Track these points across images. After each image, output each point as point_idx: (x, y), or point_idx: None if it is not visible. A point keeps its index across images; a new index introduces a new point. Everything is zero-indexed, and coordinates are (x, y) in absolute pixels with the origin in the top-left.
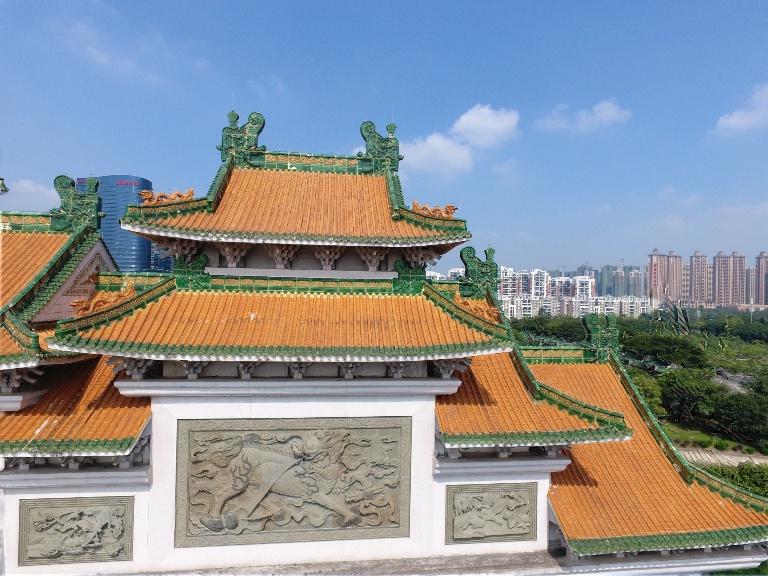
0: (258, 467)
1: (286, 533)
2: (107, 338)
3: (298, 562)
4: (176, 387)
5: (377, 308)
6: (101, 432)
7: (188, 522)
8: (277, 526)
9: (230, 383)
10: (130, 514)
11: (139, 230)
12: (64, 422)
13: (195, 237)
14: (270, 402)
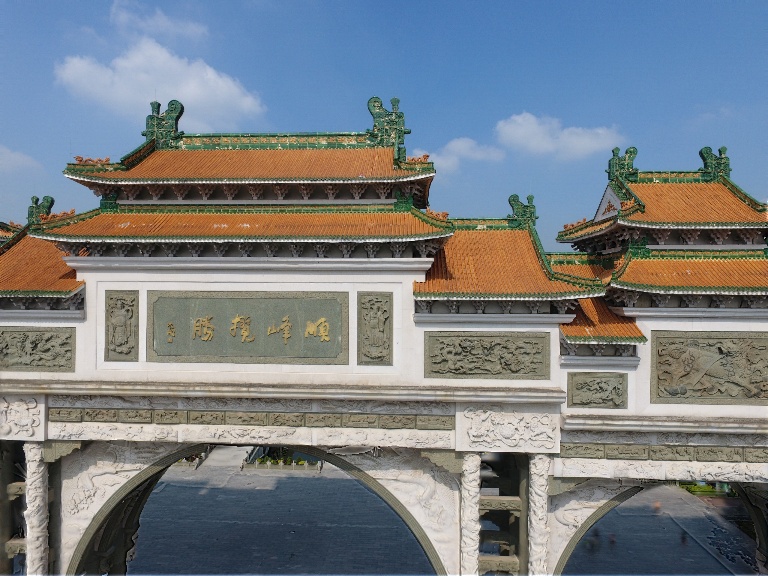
0: (698, 359)
1: (714, 399)
2: (631, 282)
3: (723, 416)
4: (656, 311)
5: (760, 267)
6: None
7: (657, 389)
8: (709, 395)
9: (687, 309)
10: (625, 383)
11: (627, 224)
12: (597, 329)
13: (655, 226)
14: (704, 322)
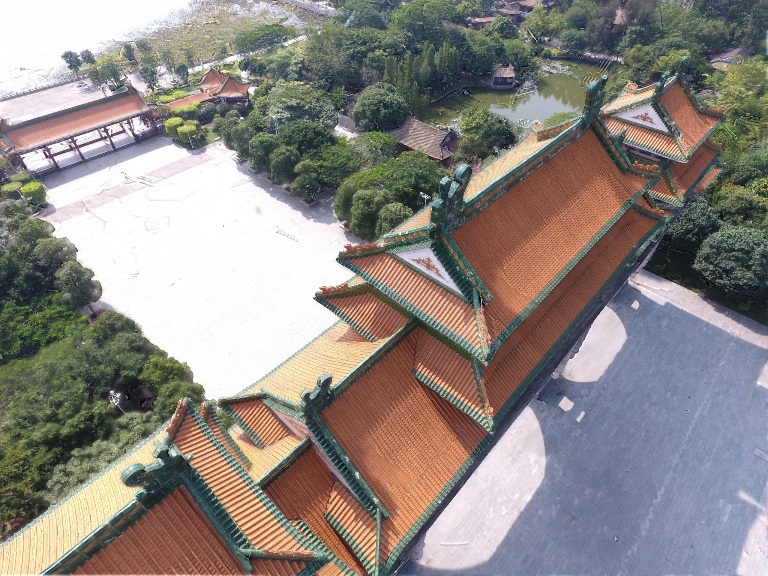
0: None
1: None
2: None
3: None
4: None
5: None
6: None
7: None
8: None
9: None
10: None
11: None
12: None
13: None
14: None
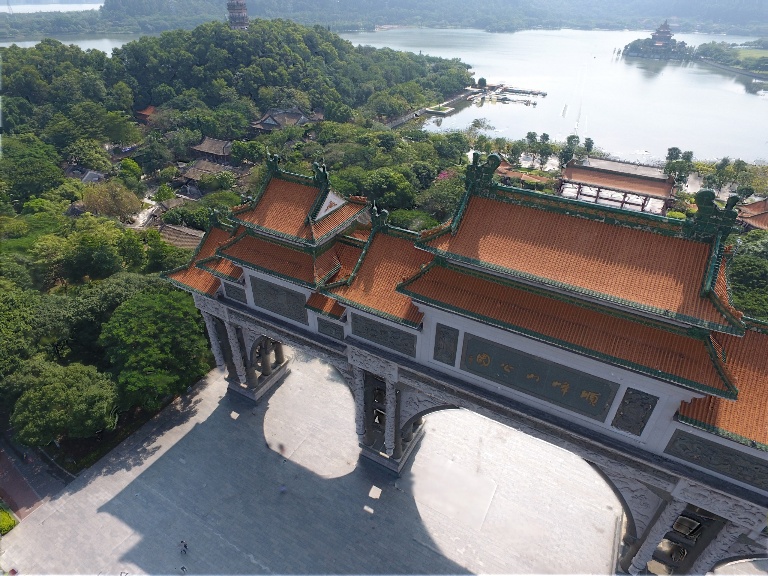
0: None
1: None
2: None
3: None
4: None
5: None
6: None
7: None
8: None
9: None
10: None
11: None
12: None
13: None
14: None
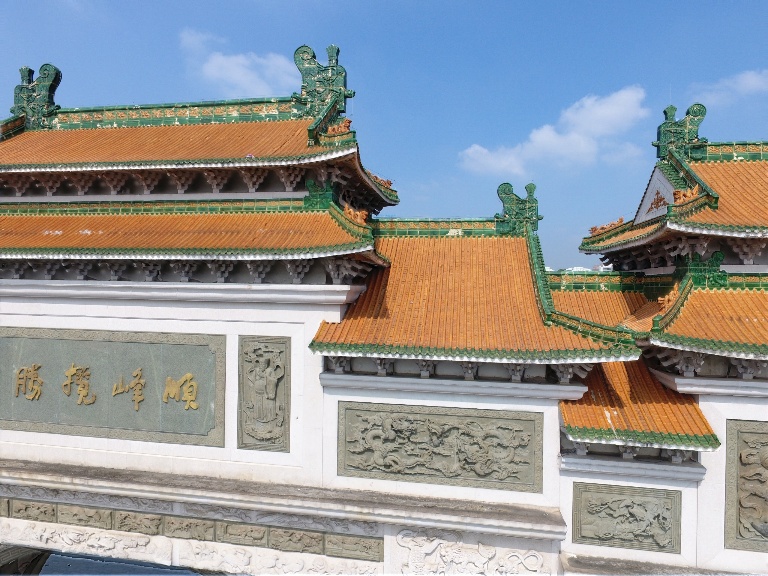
0: None
1: None
2: None
3: None
4: (737, 387)
5: None
6: (675, 427)
7: (738, 524)
8: None
9: None
10: (677, 508)
11: (684, 229)
12: (626, 414)
13: (738, 234)
14: None
